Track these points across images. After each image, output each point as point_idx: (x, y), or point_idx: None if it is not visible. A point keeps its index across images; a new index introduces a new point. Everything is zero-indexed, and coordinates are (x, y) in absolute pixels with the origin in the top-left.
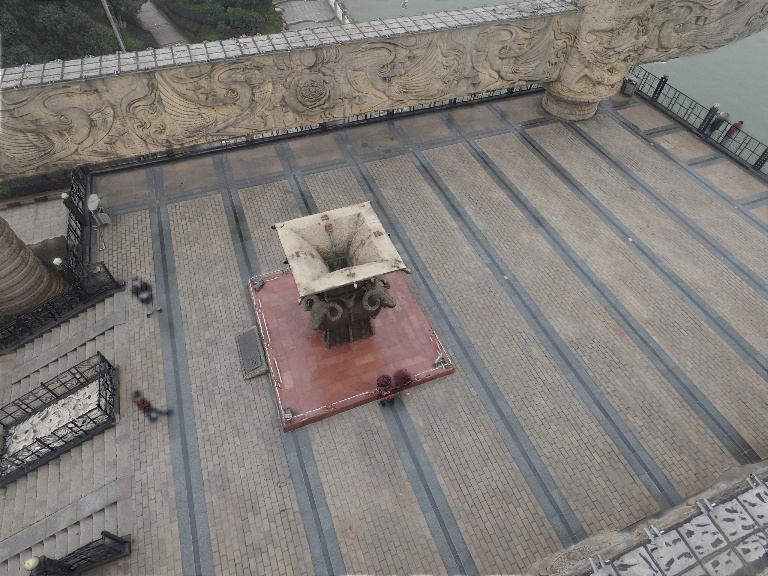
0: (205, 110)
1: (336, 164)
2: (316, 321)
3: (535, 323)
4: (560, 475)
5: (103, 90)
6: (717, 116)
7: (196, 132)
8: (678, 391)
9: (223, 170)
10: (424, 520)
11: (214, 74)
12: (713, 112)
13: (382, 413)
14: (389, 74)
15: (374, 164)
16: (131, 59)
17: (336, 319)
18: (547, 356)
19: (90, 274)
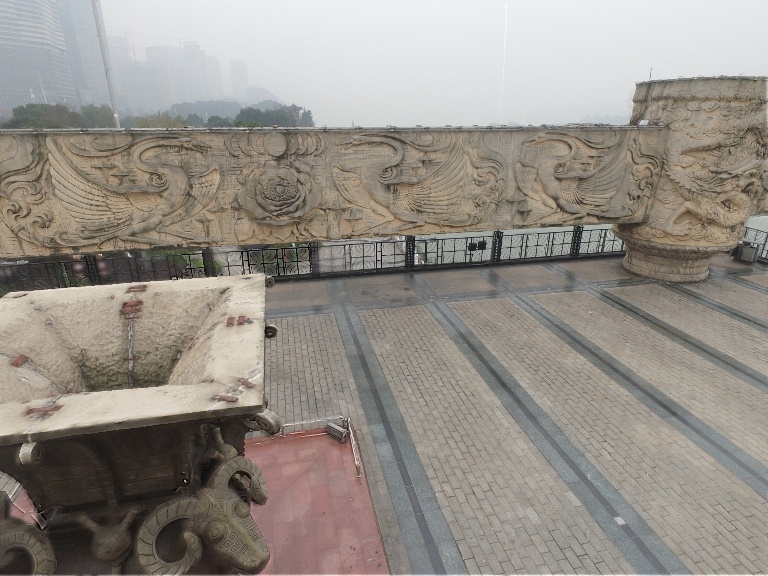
0: (116, 200)
1: (316, 310)
2: None
3: None
4: None
5: None
6: None
7: (99, 232)
8: None
9: None
10: None
11: (135, 150)
12: None
13: None
14: (394, 180)
15: (372, 312)
16: None
17: None
18: None
19: None
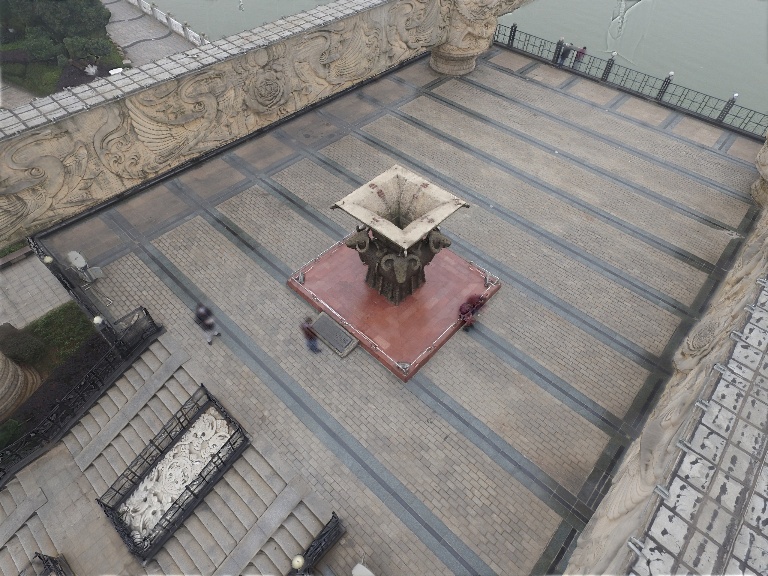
0: (176, 130)
1: (293, 159)
2: (403, 275)
3: (533, 231)
4: (613, 325)
5: (73, 130)
6: (564, 47)
7: (169, 155)
8: (647, 243)
9: (185, 194)
10: (549, 394)
11: (180, 90)
12: (560, 45)
13: (470, 336)
14: (328, 60)
15: (327, 150)
16: (88, 92)
17: (417, 268)
18: (555, 251)
19: (128, 325)
